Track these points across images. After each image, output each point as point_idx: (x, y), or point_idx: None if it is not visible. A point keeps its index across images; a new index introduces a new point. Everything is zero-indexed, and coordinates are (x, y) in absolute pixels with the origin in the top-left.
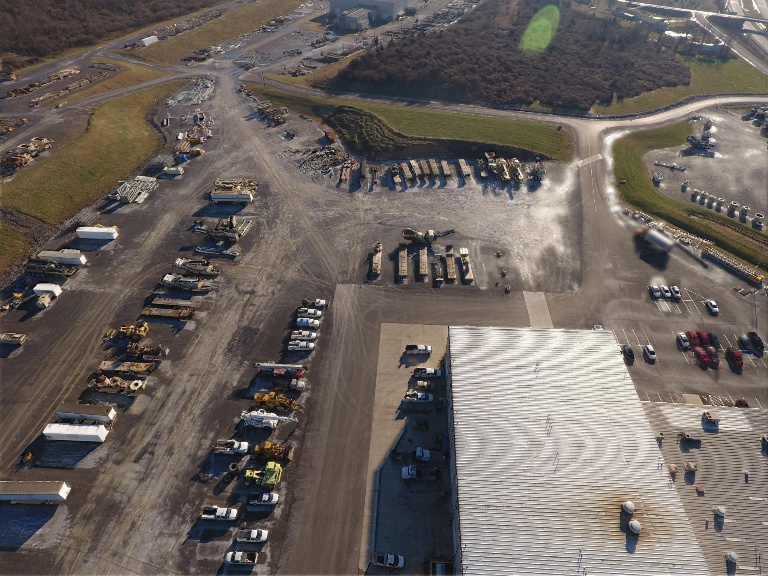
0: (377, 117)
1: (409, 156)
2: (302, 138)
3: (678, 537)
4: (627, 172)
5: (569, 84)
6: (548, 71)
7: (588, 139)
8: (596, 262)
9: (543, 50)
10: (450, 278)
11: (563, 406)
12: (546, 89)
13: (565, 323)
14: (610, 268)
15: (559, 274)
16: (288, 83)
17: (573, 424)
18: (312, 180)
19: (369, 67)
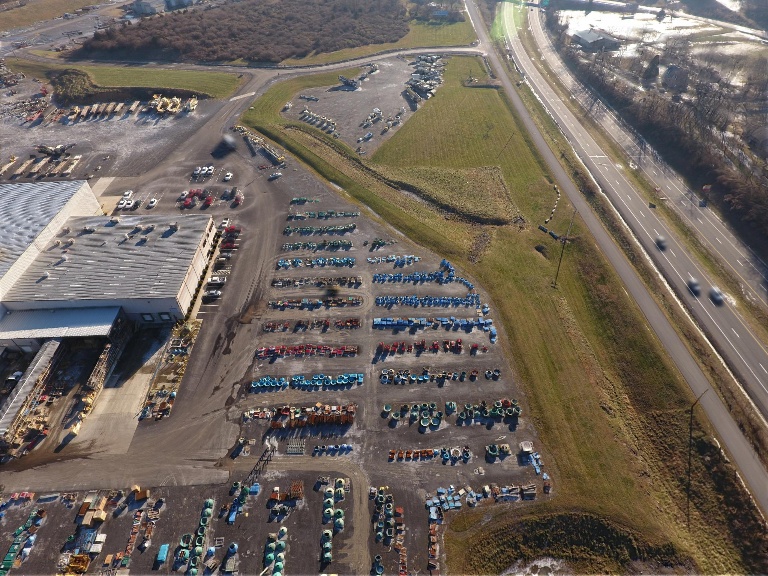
0: (88, 75)
1: (98, 102)
2: (21, 95)
3: (4, 262)
4: (263, 102)
5: (279, 44)
6: (270, 35)
7: (256, 82)
8: (174, 158)
9: (279, 20)
10: (52, 173)
11: (7, 216)
12: (254, 49)
13: (111, 192)
14: (181, 161)
15: (139, 166)
16: (41, 56)
17: (3, 223)
18: (4, 122)
19: (110, 39)
